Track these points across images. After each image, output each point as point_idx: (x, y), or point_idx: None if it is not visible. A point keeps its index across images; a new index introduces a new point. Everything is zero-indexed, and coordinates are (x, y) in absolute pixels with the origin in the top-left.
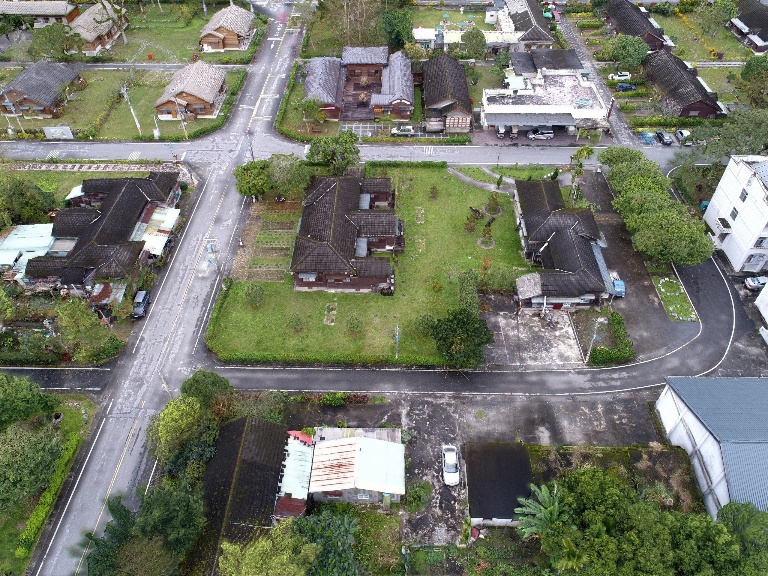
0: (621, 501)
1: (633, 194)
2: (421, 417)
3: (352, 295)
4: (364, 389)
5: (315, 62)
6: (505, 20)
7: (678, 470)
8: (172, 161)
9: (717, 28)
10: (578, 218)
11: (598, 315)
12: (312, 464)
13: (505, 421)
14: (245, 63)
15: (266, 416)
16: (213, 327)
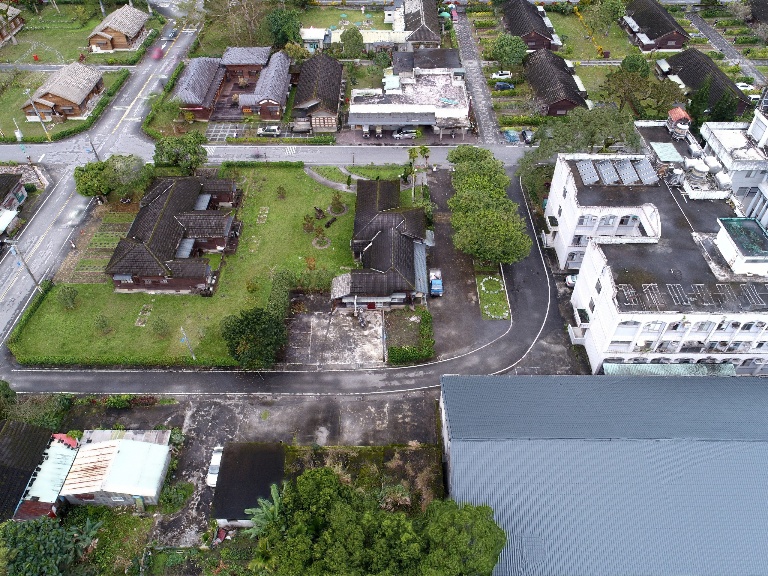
0: (334, 501)
1: (462, 193)
2: (205, 418)
3: (171, 296)
4: (156, 391)
5: (192, 62)
6: (399, 20)
7: (427, 468)
8: (29, 163)
9: (608, 27)
10: (404, 217)
11: (412, 314)
12: (71, 467)
13: (288, 421)
14: (131, 64)
15: (38, 419)
16: (19, 330)
